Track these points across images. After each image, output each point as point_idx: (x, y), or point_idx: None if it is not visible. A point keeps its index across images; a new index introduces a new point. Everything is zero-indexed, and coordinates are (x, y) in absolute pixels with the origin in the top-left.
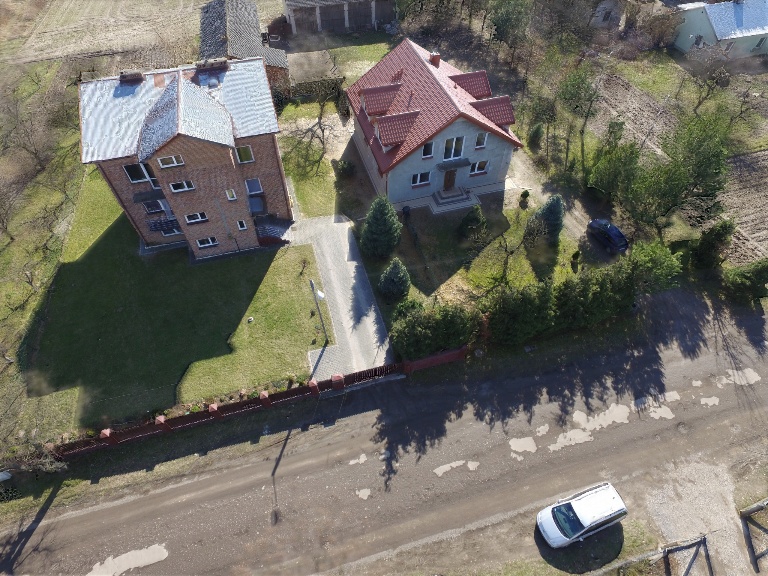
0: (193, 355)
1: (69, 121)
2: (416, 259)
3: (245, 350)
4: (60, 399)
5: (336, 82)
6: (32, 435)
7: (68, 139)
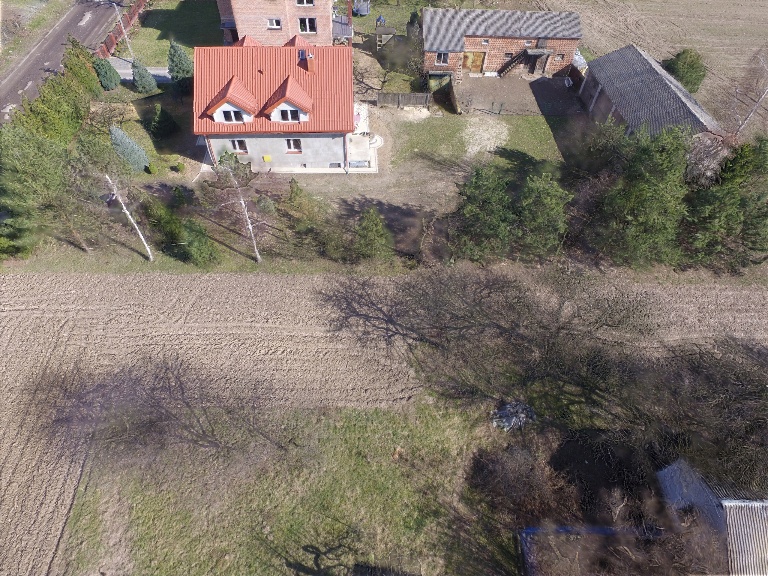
0: (166, 31)
1: (424, 2)
2: (166, 102)
3: (154, 43)
4: (172, 6)
5: None
6: (160, 2)
7: None
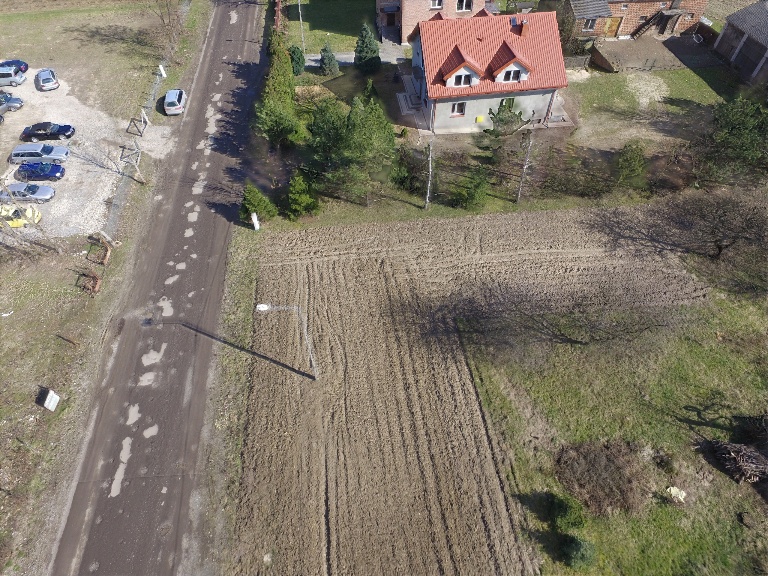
0: (313, 23)
1: None
2: (353, 82)
3: None
4: (305, 1)
5: None
6: None
7: None
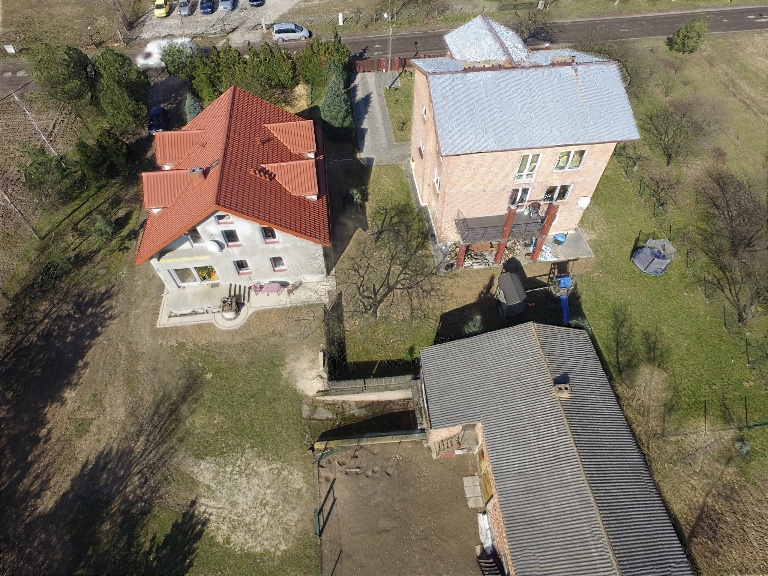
0: None
1: None
2: None
3: None
4: None
5: None
6: None
7: (764, 323)
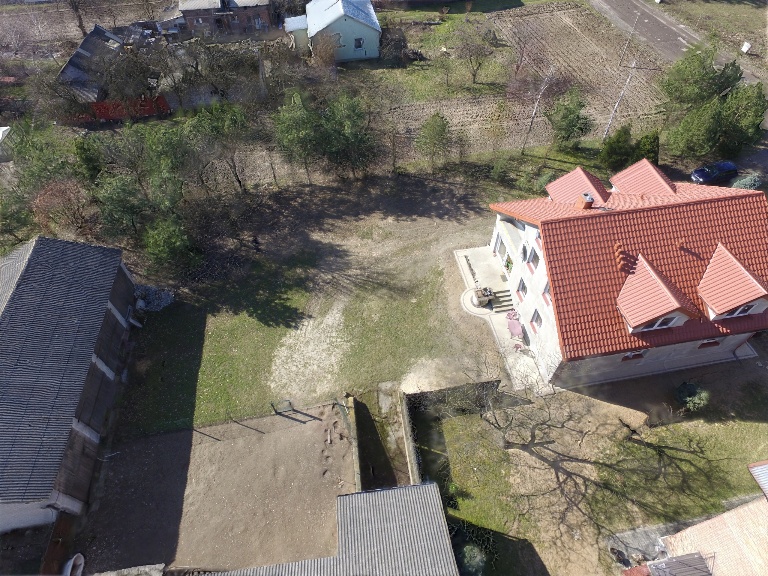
0: None
1: None
2: None
3: None
4: None
5: (411, 401)
6: None
7: None
